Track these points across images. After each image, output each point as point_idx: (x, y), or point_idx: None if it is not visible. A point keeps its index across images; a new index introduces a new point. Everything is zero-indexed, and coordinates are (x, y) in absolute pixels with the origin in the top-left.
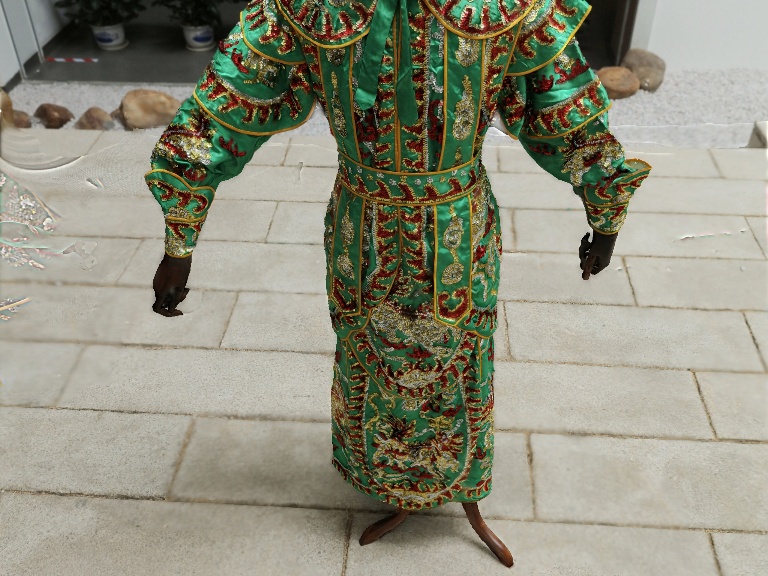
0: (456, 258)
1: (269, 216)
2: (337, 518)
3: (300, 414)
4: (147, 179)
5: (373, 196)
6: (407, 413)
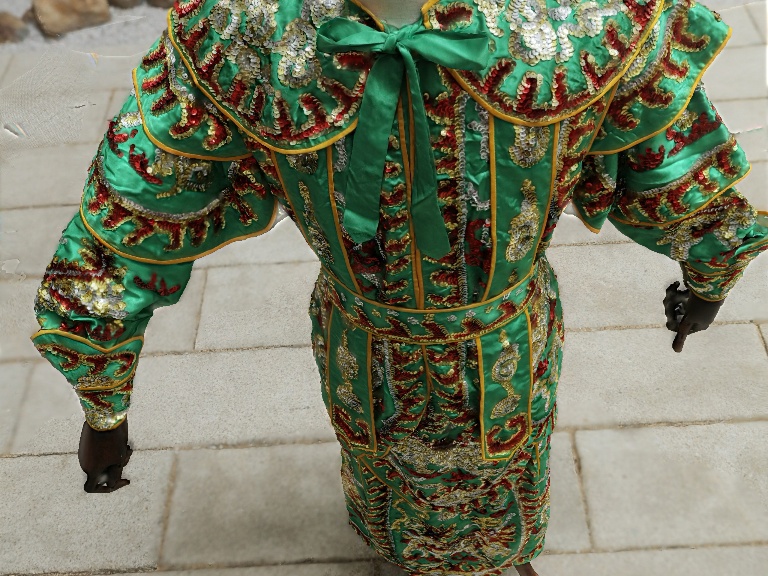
0: (510, 390)
1: None
2: (362, 573)
3: (301, 434)
4: (35, 343)
5: (383, 333)
6: (445, 522)
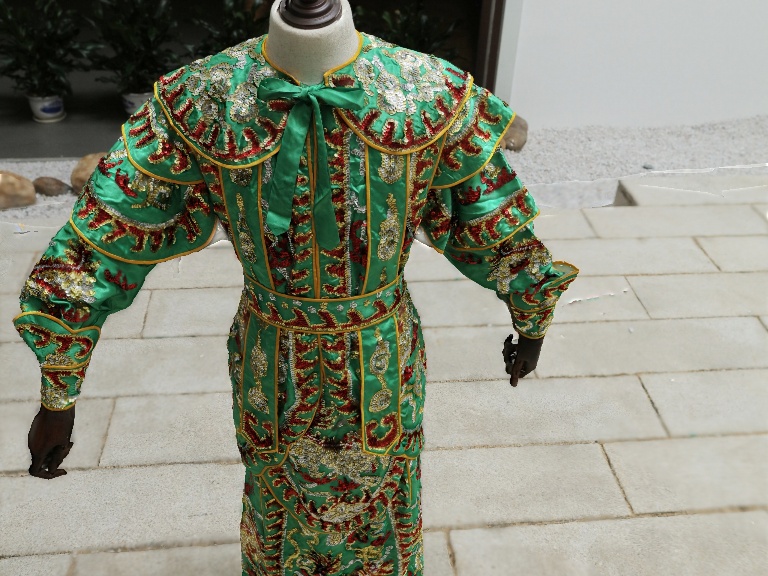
0: (384, 384)
1: (143, 307)
2: None
3: (198, 537)
4: (16, 324)
5: (289, 325)
6: (332, 548)
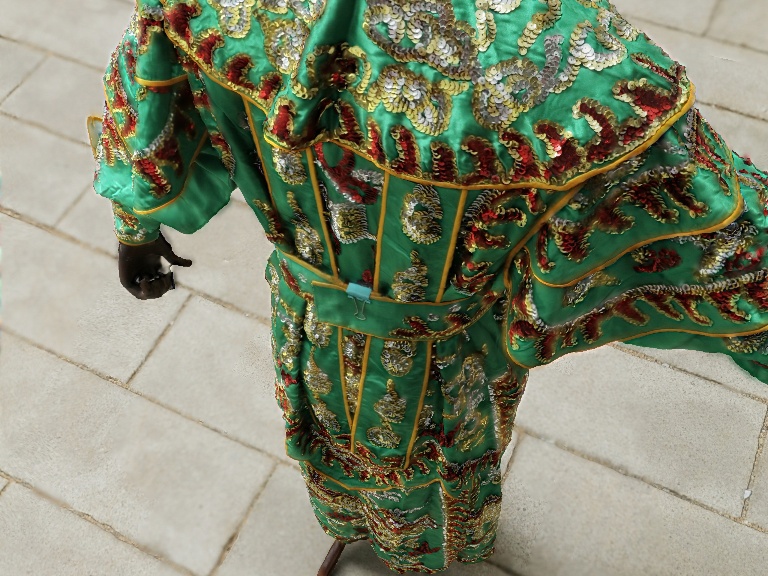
0: None
1: None
2: None
3: None
4: None
5: None
6: None
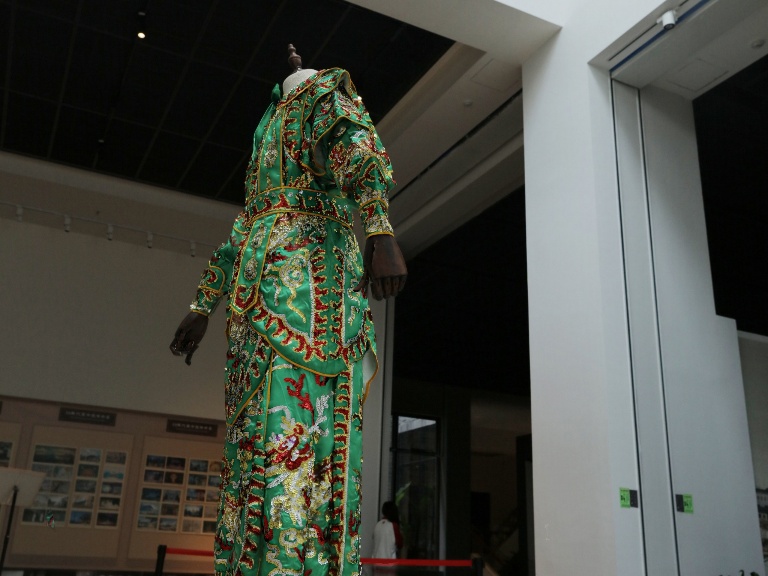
0: (254, 255)
1: None
2: None
3: None
4: None
5: None
6: None
